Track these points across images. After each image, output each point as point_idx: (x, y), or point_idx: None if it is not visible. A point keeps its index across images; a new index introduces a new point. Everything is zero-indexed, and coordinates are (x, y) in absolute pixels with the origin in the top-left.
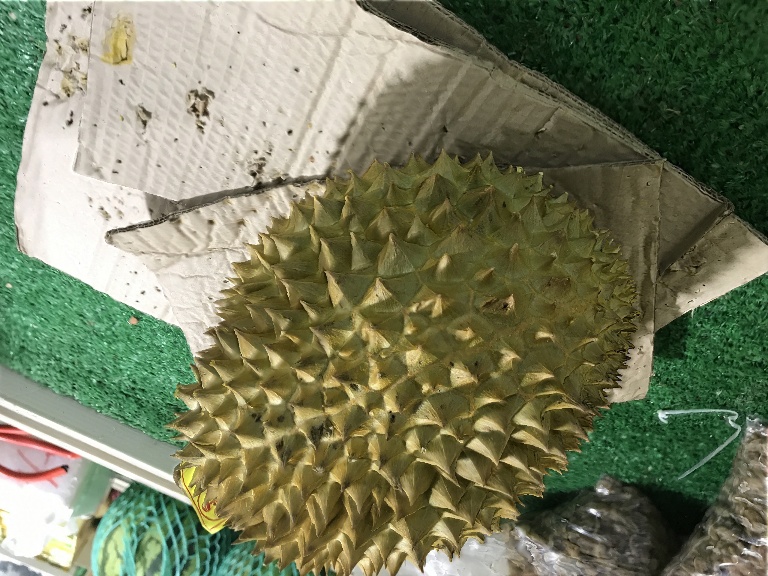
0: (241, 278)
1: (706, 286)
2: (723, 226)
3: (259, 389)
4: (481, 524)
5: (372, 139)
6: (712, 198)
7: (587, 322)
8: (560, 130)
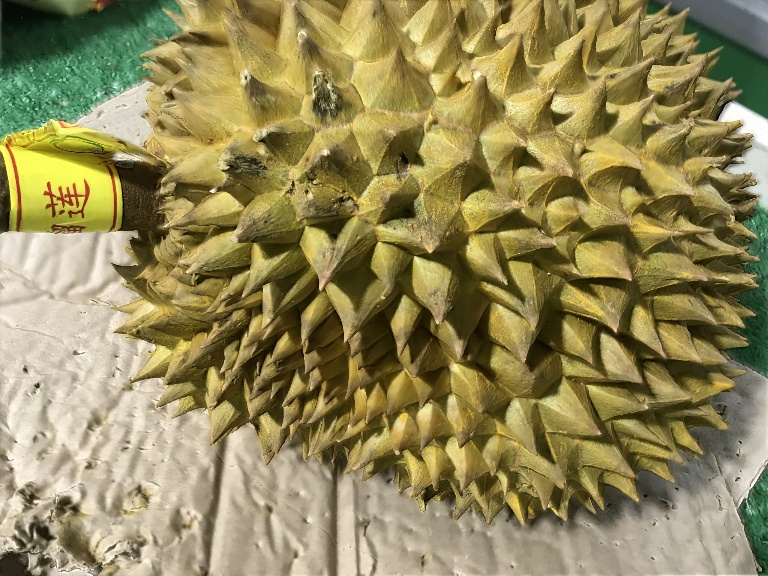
0: None
1: (743, 444)
2: None
3: None
4: None
5: None
6: None
7: None
8: None
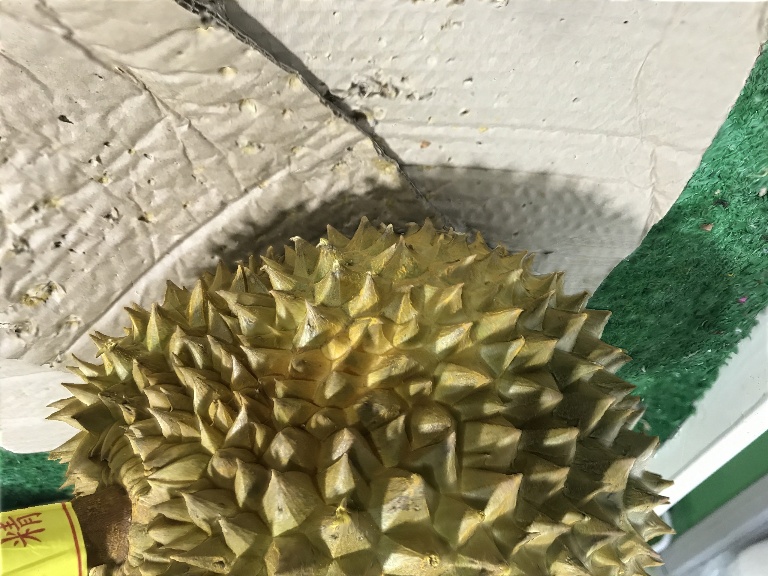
0: (451, 342)
1: None
2: None
3: (511, 575)
4: None
5: (502, 199)
6: None
7: None
8: None
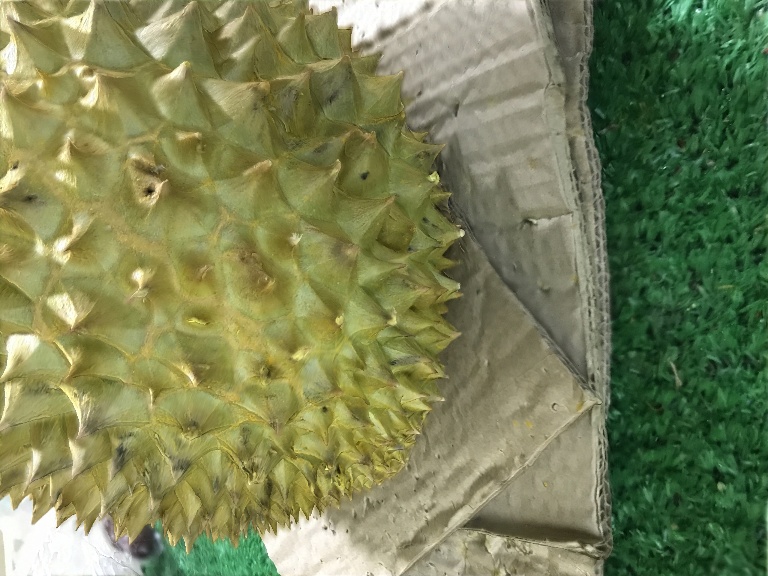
0: None
1: None
2: (577, 567)
3: None
4: None
5: (400, 56)
6: (597, 515)
7: (234, 367)
8: (547, 242)
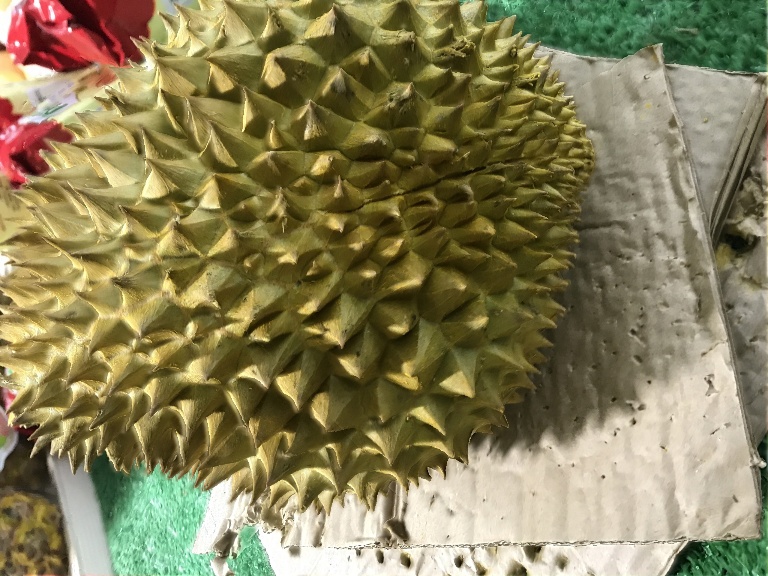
0: None
1: None
2: None
3: None
4: (173, 204)
5: None
6: (746, 75)
7: None
8: None
